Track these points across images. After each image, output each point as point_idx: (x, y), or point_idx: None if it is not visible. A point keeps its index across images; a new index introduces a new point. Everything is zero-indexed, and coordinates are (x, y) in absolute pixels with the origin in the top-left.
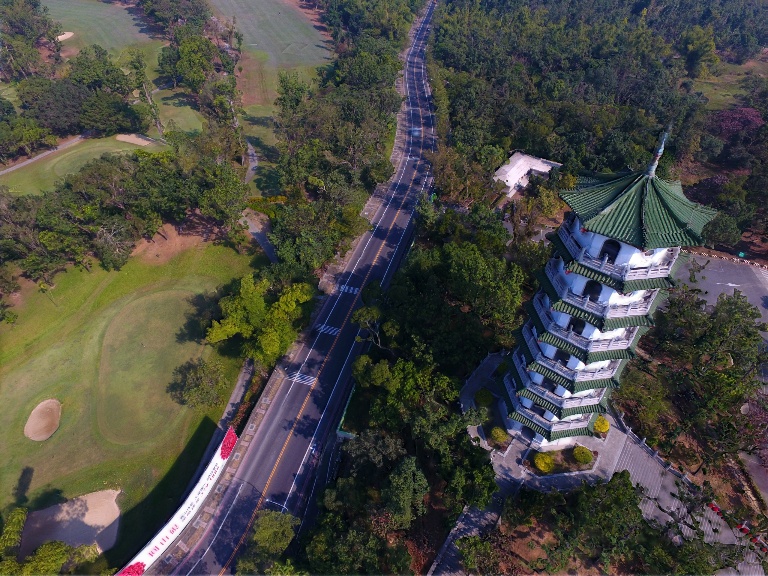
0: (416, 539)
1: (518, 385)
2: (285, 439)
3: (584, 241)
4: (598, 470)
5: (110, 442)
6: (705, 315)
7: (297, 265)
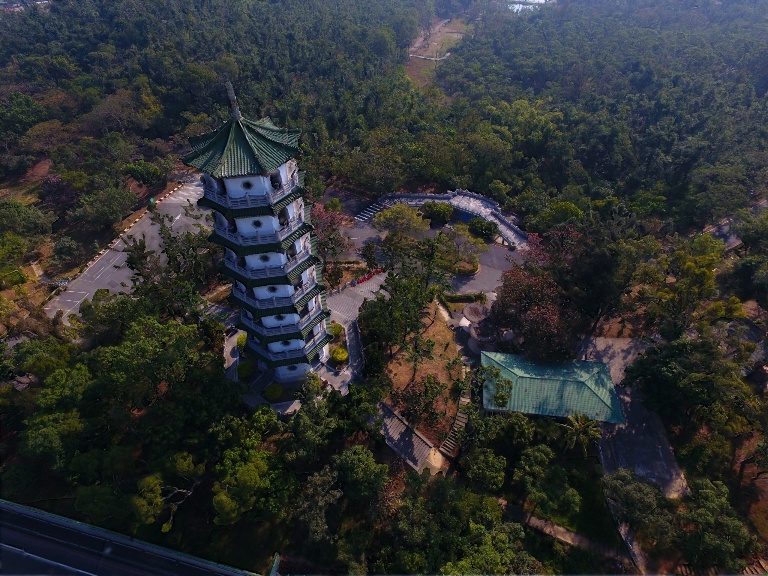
0: (395, 471)
1: (296, 337)
2: None
3: (259, 190)
4: (345, 325)
5: None
6: None
7: None
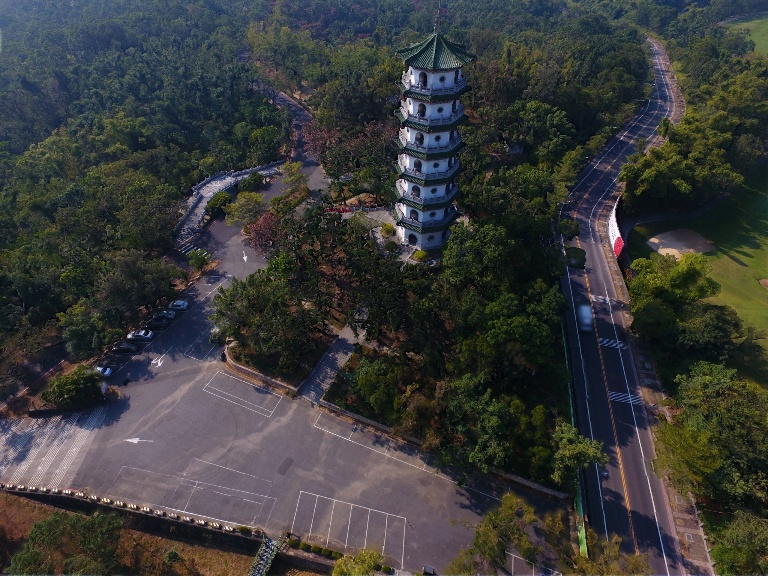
0: None
1: None
2: None
3: None
4: None
5: (709, 274)
6: (269, 289)
7: (690, 343)
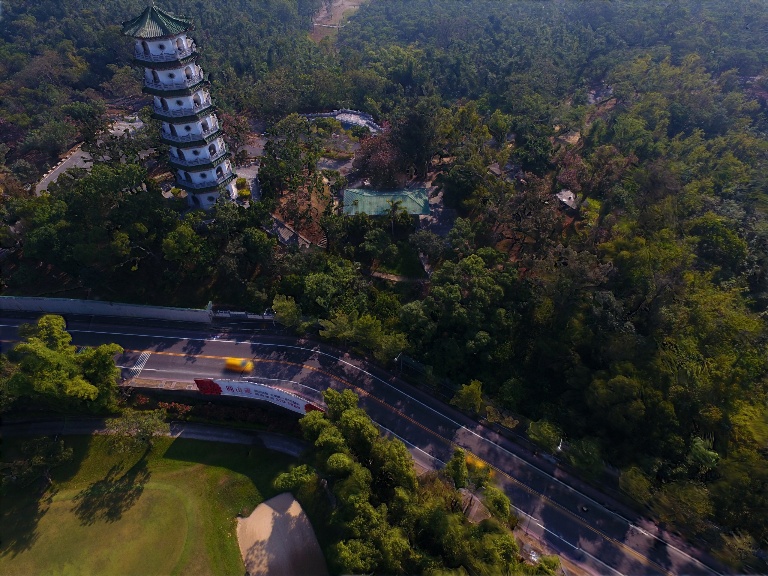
0: (284, 251)
1: (209, 166)
2: (205, 359)
3: (170, 50)
4: (249, 180)
5: (182, 554)
6: None
7: None
